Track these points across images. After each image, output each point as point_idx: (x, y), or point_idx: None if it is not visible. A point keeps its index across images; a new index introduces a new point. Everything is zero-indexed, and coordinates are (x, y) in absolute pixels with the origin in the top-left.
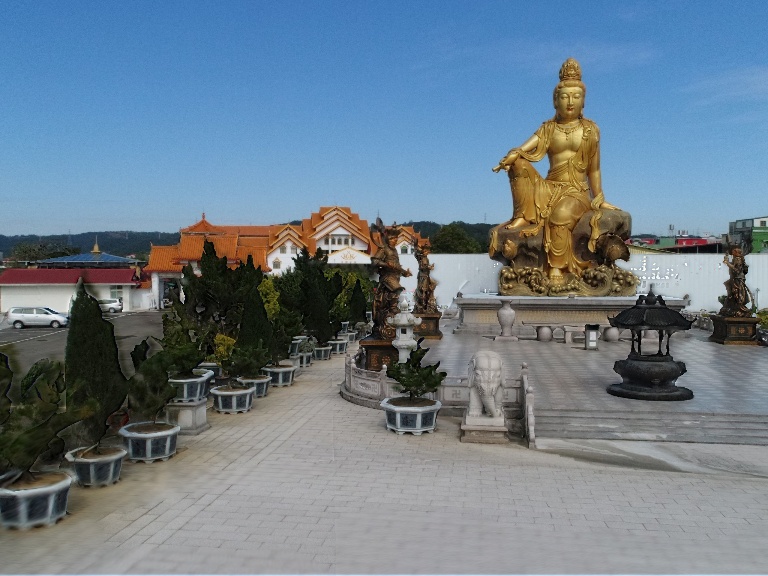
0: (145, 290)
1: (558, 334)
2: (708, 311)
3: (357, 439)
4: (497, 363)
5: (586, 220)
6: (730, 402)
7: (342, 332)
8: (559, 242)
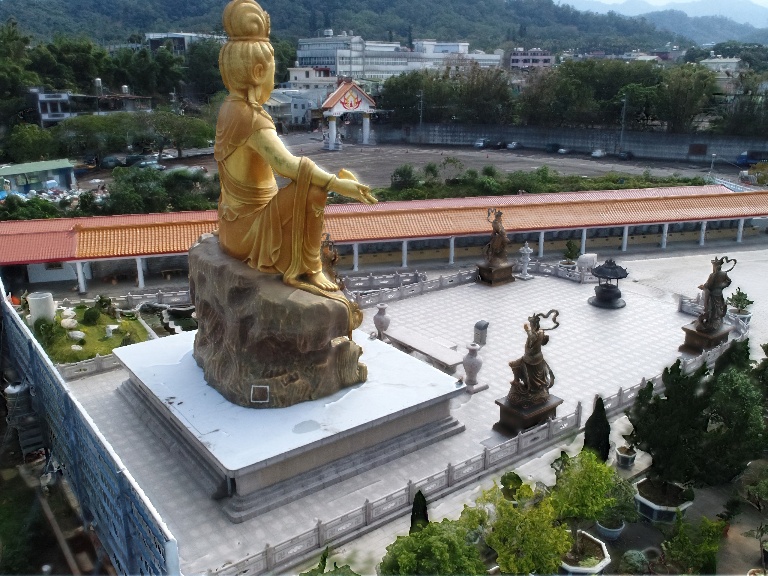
0: None
1: None
2: None
3: (766, 323)
4: None
5: None
6: (592, 293)
7: None
8: None
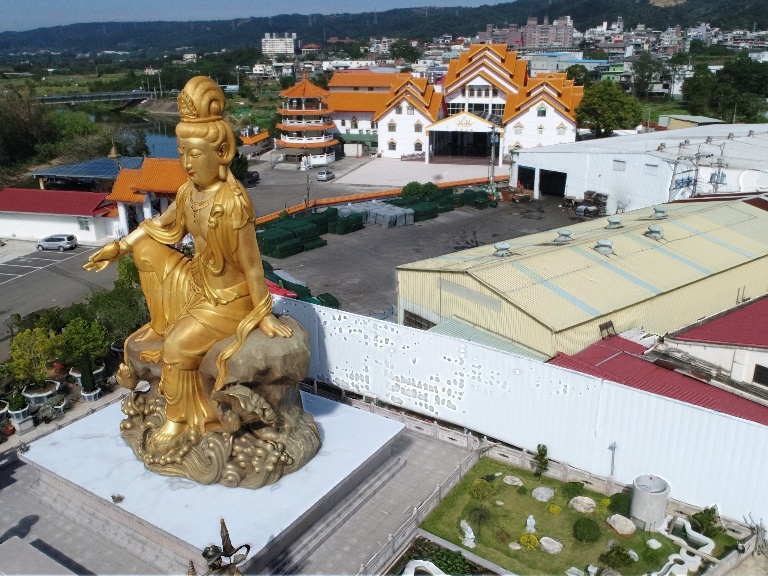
0: (113, 218)
1: (107, 540)
2: (531, 455)
3: None
4: None
5: (213, 355)
6: None
7: None
8: (167, 386)
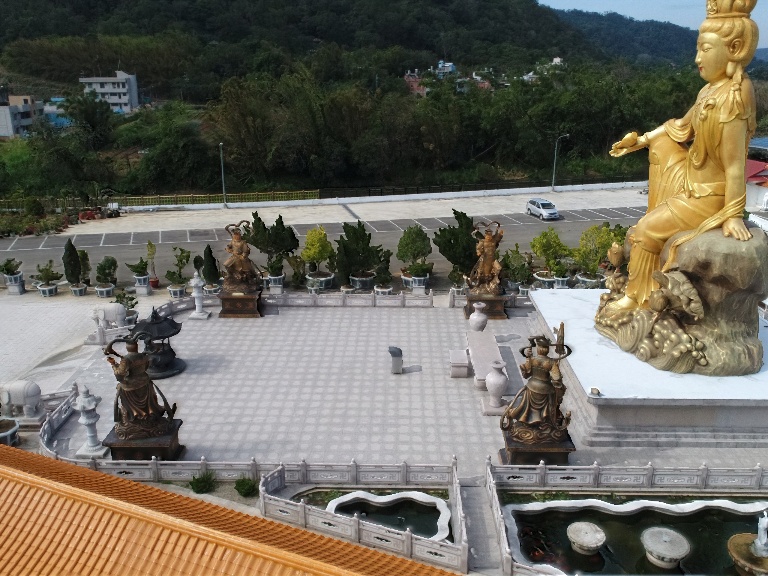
0: None
1: None
2: None
3: None
4: (94, 308)
5: (671, 242)
6: None
7: (414, 284)
8: None
